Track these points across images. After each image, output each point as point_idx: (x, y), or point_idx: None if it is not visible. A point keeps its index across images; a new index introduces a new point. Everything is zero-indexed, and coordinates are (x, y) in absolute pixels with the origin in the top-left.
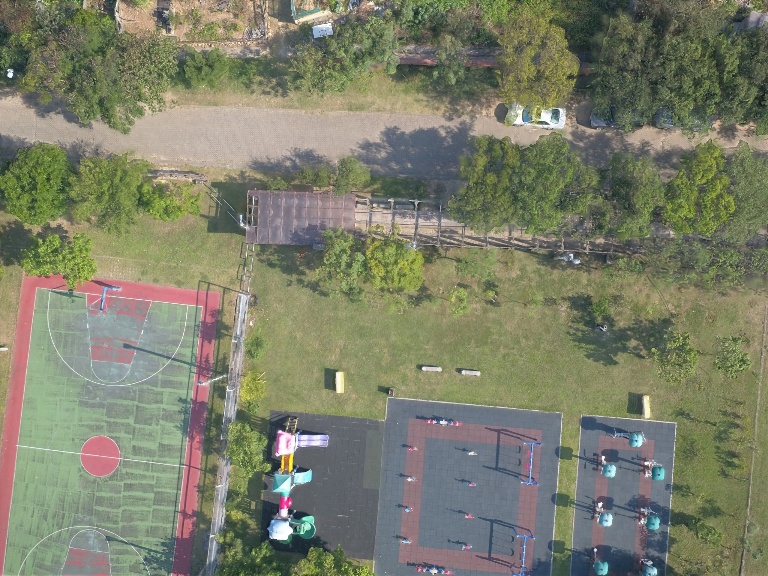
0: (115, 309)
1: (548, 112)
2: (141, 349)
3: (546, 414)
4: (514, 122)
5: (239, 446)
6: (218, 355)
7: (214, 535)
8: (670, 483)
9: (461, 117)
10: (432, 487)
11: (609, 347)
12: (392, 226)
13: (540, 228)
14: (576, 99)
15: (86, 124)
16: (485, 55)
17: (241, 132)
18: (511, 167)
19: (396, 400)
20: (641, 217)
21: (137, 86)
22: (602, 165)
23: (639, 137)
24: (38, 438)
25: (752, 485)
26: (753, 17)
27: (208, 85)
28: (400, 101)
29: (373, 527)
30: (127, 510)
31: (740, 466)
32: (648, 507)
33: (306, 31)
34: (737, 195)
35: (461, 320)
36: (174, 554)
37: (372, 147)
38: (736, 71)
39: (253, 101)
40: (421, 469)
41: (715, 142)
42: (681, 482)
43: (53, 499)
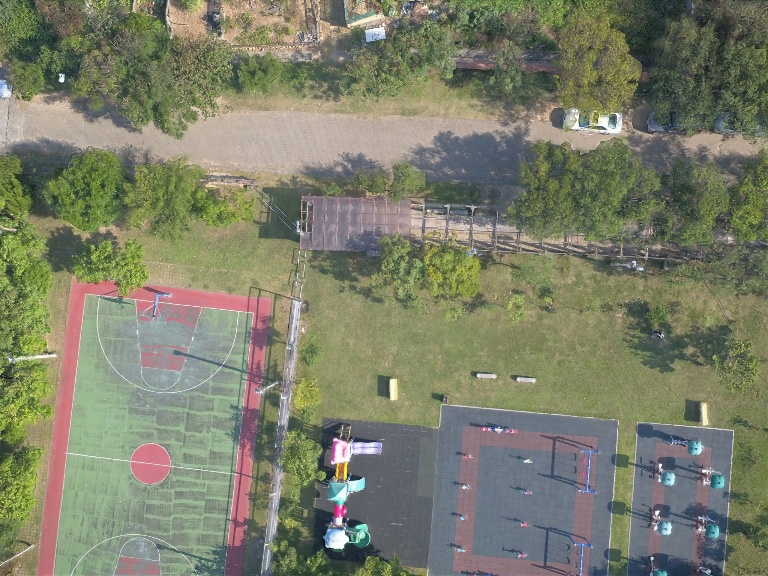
0: (165, 315)
1: (605, 117)
2: (191, 356)
3: (602, 421)
4: None
5: (294, 454)
6: (269, 362)
7: (268, 544)
8: (727, 491)
9: (516, 122)
10: (487, 495)
11: (666, 354)
12: (446, 232)
13: (600, 234)
14: (632, 104)
15: (135, 129)
16: (539, 59)
17: (293, 137)
18: (573, 173)
19: (450, 407)
20: (705, 223)
21: (191, 91)
22: (659, 170)
23: (696, 142)
24: (88, 445)
25: None
26: None
27: (261, 90)
28: (454, 106)
29: (427, 535)
30: (178, 518)
31: None
32: (706, 515)
33: (358, 35)
34: None
35: (516, 327)
36: (225, 562)
37: (425, 152)
38: None
39: (305, 106)
40: (475, 477)
41: None
42: (739, 490)
43: (103, 507)
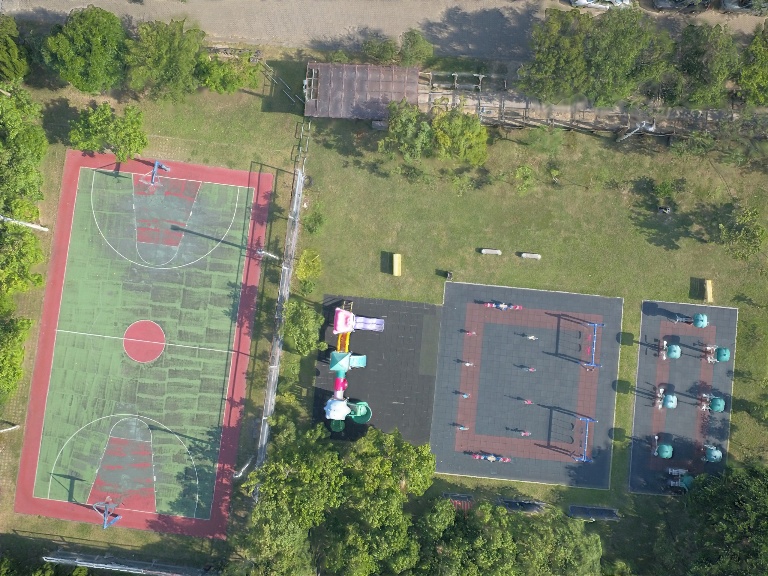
0: (163, 190)
1: None
2: (189, 231)
3: (607, 299)
4: (578, 2)
5: (295, 323)
6: (270, 238)
7: (266, 417)
8: (732, 370)
9: None
10: (490, 373)
11: (671, 231)
12: None
13: (609, 100)
14: None
15: None
16: None
17: (298, 10)
18: (584, 32)
19: (454, 284)
20: (714, 84)
21: None
22: None
23: (701, 21)
24: (79, 322)
25: None
26: None
27: None
28: None
29: (429, 414)
30: (172, 397)
31: None
32: (710, 393)
33: None
34: None
35: (521, 203)
36: (220, 443)
37: (432, 27)
38: None
39: None
40: (479, 355)
41: None
42: (743, 368)
43: (93, 386)
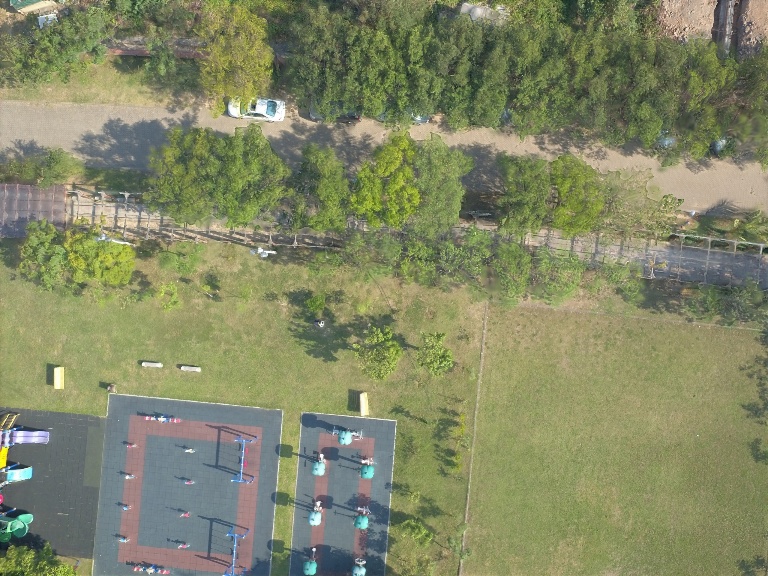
0: None
1: (263, 104)
2: None
3: (267, 411)
4: (233, 114)
5: None
6: None
7: None
8: (390, 482)
9: (184, 109)
10: (152, 485)
11: (329, 343)
12: (115, 219)
13: (240, 221)
14: (298, 92)
15: None
16: None
17: None
18: (199, 159)
19: (117, 396)
20: (328, 210)
21: None
22: None
23: (360, 130)
24: None
25: (471, 484)
26: (464, 9)
27: None
28: (124, 93)
29: (93, 525)
30: None
31: (457, 465)
32: (366, 506)
33: (32, 21)
34: (420, 188)
35: (183, 315)
36: None
37: (96, 139)
38: (422, 62)
39: None
40: (141, 467)
41: None
42: (400, 481)
43: None
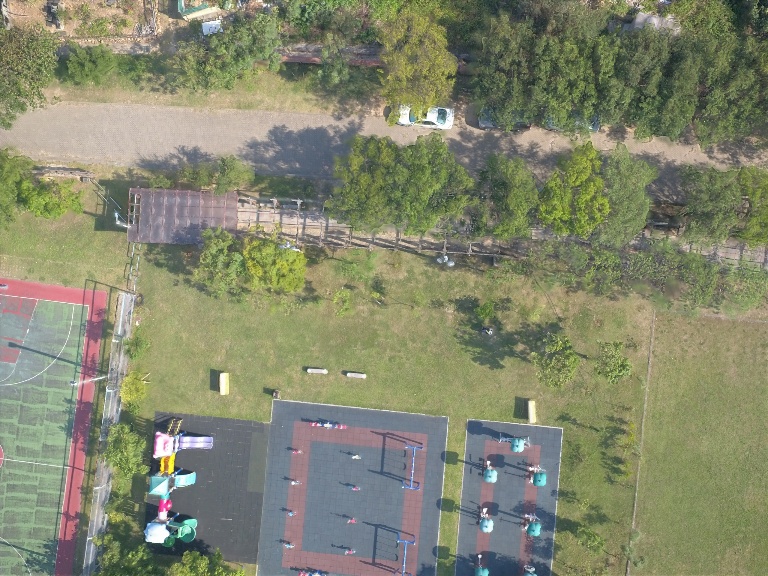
0: (1, 307)
1: (434, 112)
2: (26, 348)
3: (432, 418)
4: (401, 122)
5: (116, 447)
6: (104, 355)
7: (92, 537)
8: (556, 489)
9: (350, 116)
10: (317, 491)
11: (496, 351)
12: None
13: (419, 229)
14: (465, 99)
15: None
16: (376, 54)
17: (129, 129)
18: (386, 167)
19: (281, 402)
20: (516, 219)
21: (17, 81)
22: None
23: (528, 138)
24: None
25: (638, 492)
26: (639, 18)
27: (93, 81)
28: (289, 100)
29: (257, 531)
30: (10, 511)
31: (625, 472)
32: (533, 513)
33: (196, 28)
34: (611, 198)
35: (348, 322)
36: (56, 556)
37: (260, 146)
38: (612, 72)
39: (142, 98)
40: (306, 472)
41: (604, 144)
42: (567, 488)
43: None
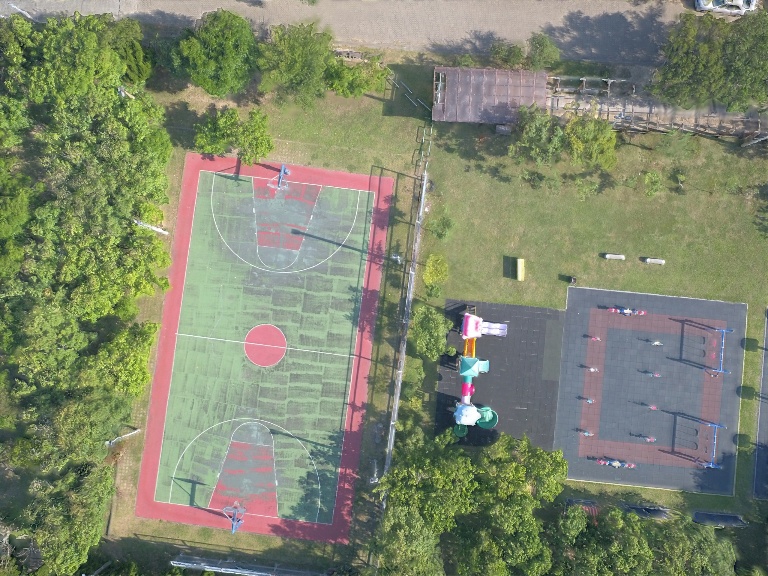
0: (283, 193)
1: None
2: (310, 235)
3: (731, 305)
4: (703, 7)
5: (425, 328)
6: (391, 242)
7: (394, 422)
8: None
9: (646, 3)
10: (614, 379)
11: None
12: None
13: (742, 105)
14: None
15: (256, 3)
16: None
17: (419, 14)
18: (723, 37)
19: (577, 289)
20: None
21: None
22: None
23: None
24: (199, 326)
25: None
26: None
27: None
28: None
29: (552, 420)
30: (293, 402)
31: None
32: None
33: None
34: None
35: (645, 208)
36: (342, 448)
37: (555, 31)
38: None
39: None
40: (602, 360)
41: None
42: None
43: (214, 390)
